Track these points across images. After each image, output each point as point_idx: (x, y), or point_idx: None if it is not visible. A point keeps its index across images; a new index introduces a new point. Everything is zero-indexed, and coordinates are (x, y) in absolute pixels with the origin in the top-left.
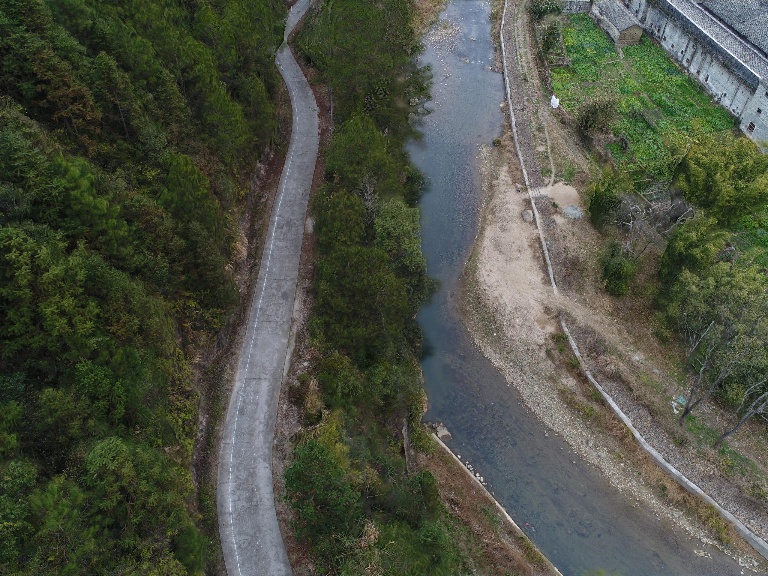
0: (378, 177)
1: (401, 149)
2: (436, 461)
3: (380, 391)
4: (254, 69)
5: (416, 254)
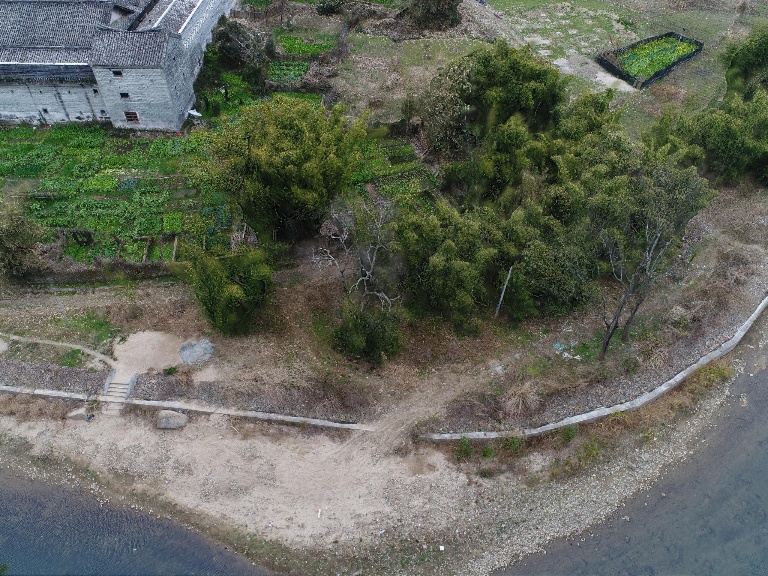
0: None
1: None
2: None
3: None
4: None
5: None
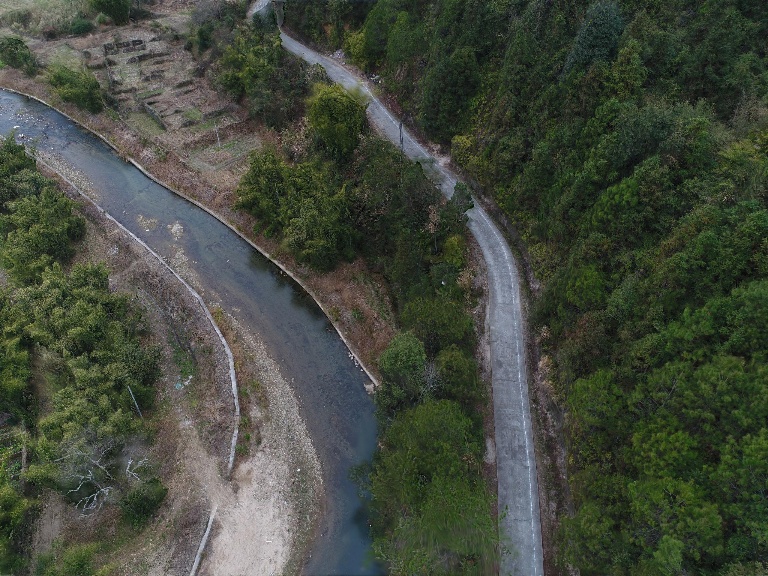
0: None
1: None
2: None
3: None
4: (616, 572)
5: None
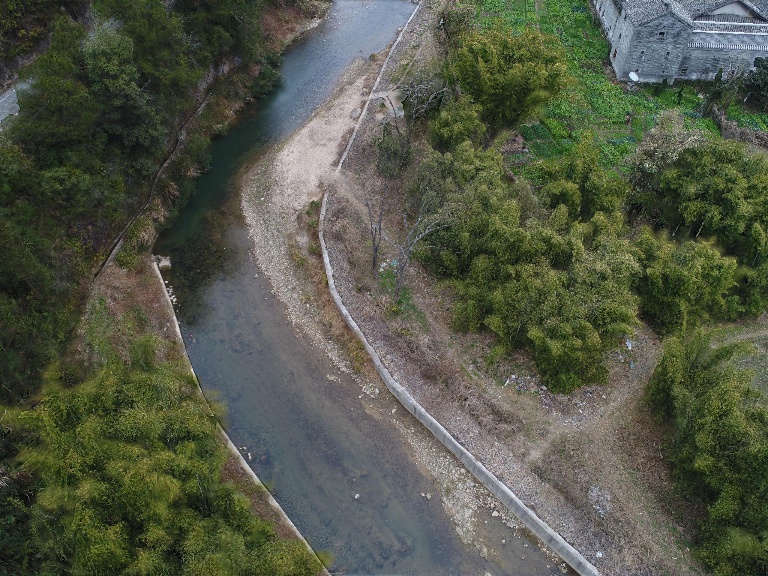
0: (126, 19)
1: (252, 43)
2: (131, 275)
3: (53, 186)
4: None
5: (121, 78)
